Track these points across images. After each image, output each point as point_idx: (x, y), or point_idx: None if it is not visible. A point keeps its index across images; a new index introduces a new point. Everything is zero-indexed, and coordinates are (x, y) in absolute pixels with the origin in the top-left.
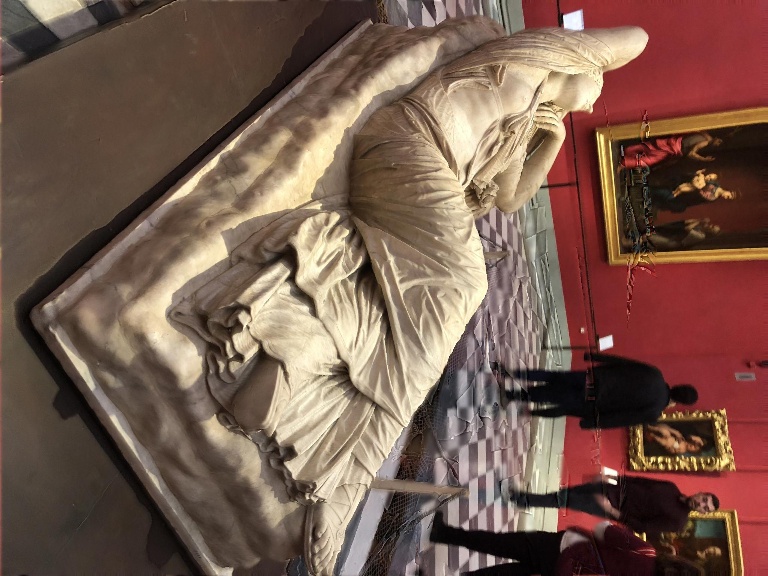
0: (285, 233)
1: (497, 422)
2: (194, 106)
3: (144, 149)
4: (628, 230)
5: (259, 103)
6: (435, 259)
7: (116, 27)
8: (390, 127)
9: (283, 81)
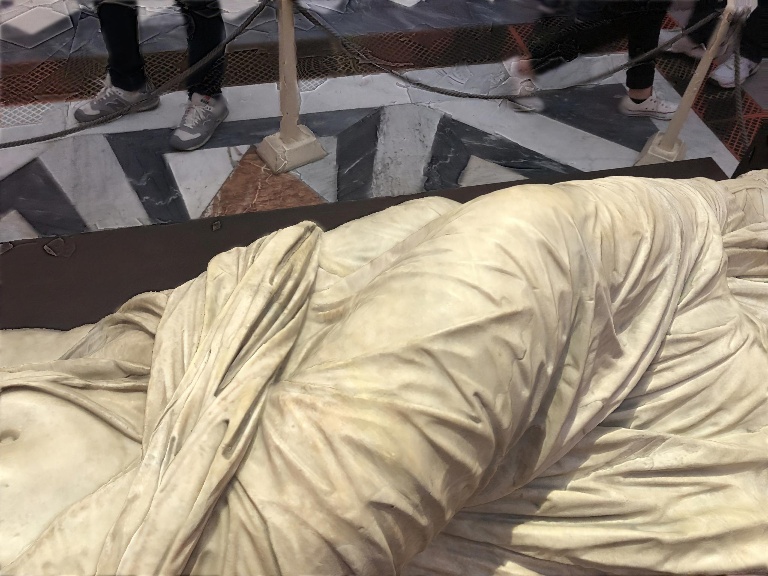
0: None
1: None
2: None
3: None
4: None
5: None
6: None
7: None
8: None
9: None
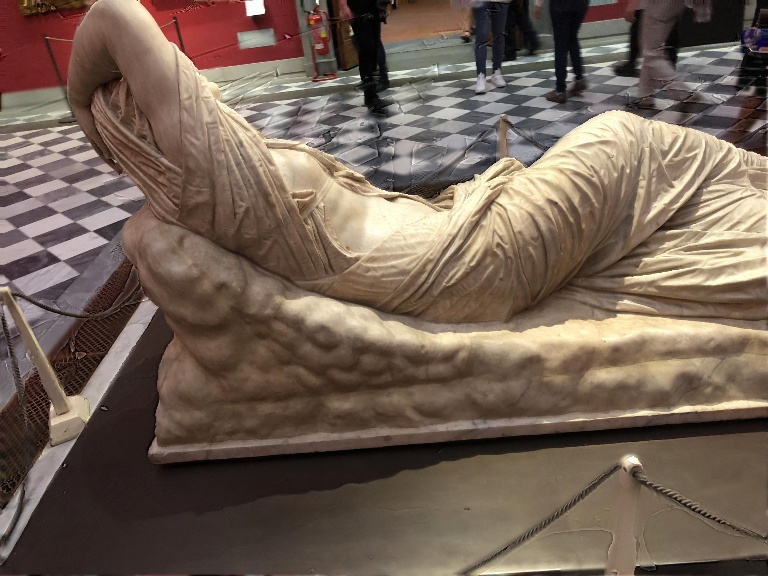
0: (767, 287)
1: (378, 118)
2: (652, 471)
3: (755, 460)
4: (207, 5)
5: (522, 445)
6: (639, 165)
7: (767, 560)
8: (488, 288)
9: (446, 452)
